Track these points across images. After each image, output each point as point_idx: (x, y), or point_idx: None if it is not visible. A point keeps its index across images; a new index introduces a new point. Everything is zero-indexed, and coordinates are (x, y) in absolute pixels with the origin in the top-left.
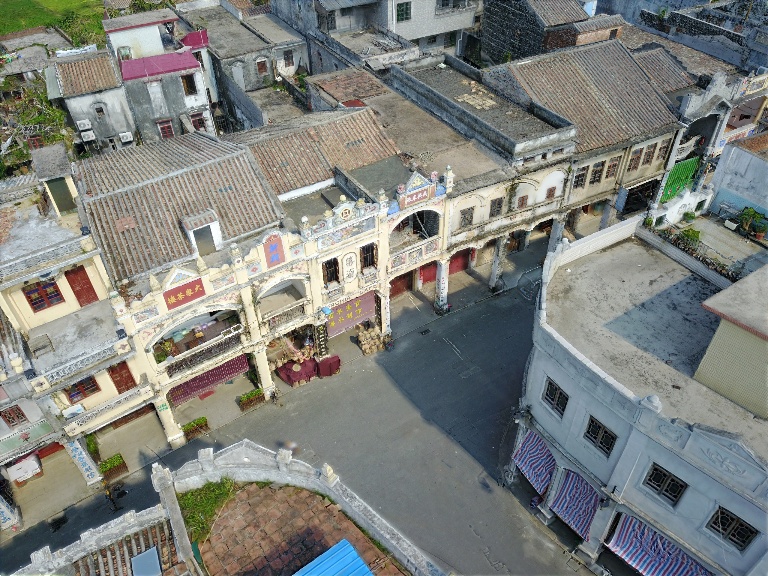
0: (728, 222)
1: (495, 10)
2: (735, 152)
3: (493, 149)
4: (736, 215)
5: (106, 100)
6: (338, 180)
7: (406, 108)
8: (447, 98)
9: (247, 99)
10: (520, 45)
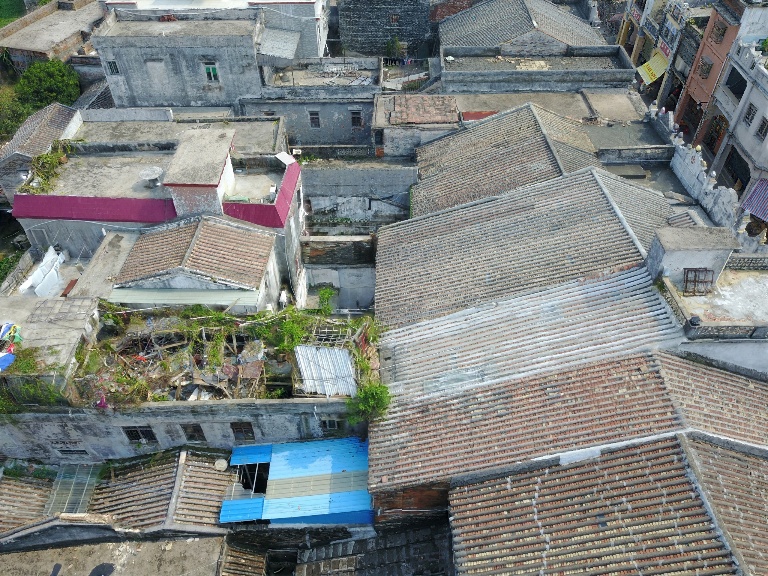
0: (757, 52)
1: (357, 7)
2: (753, 11)
3: (607, 86)
4: (761, 46)
5: (267, 267)
6: (604, 160)
7: (495, 99)
8: (540, 70)
9: (369, 172)
10: (400, 28)
